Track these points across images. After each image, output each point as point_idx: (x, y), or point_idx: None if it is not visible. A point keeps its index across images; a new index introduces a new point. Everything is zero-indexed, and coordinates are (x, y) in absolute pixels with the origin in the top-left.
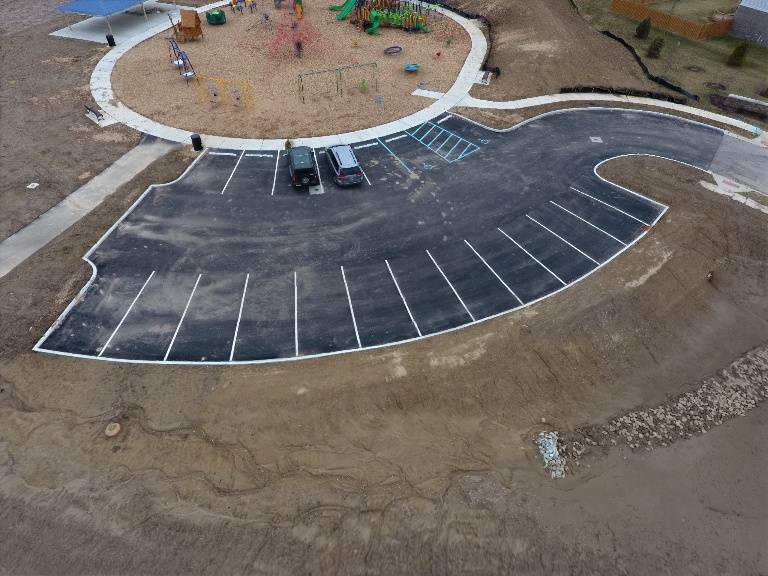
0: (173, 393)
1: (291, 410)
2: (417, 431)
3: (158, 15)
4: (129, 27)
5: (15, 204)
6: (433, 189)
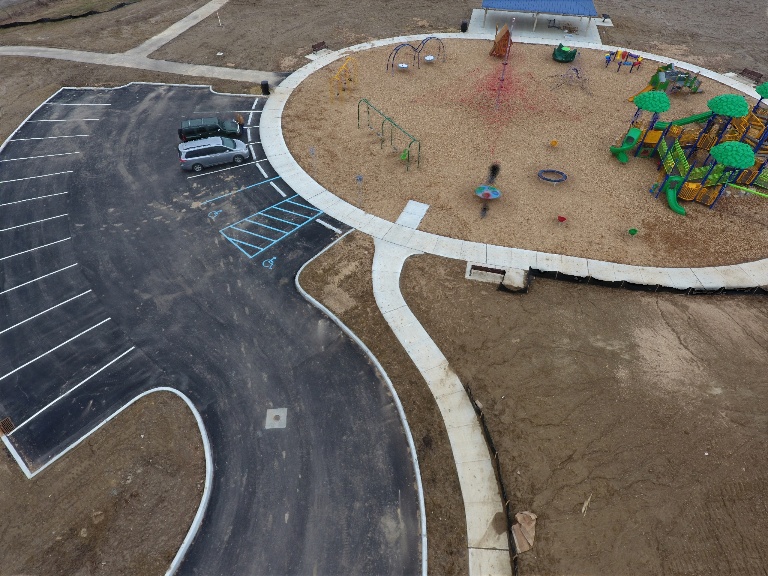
0: (0, 127)
1: None
2: None
3: (558, 32)
4: None
5: (198, 54)
6: (167, 218)
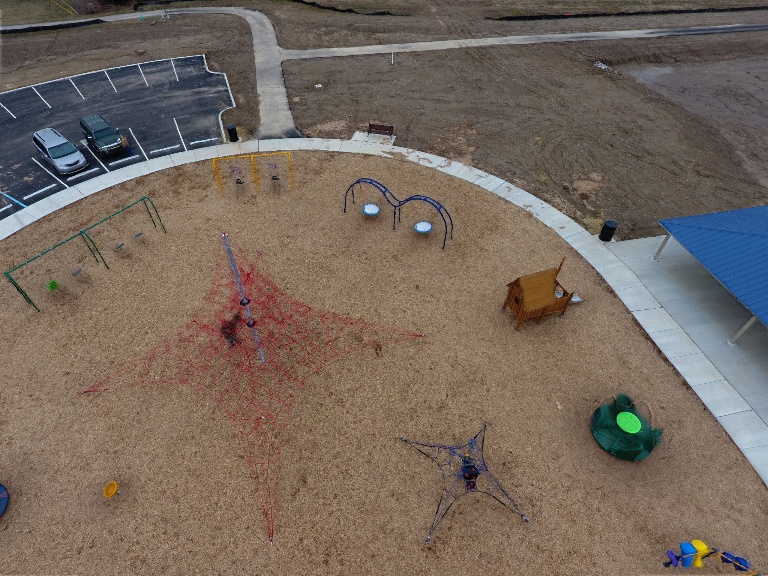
0: None
1: (66, 69)
2: (3, 82)
3: None
4: (710, 302)
5: (308, 77)
6: None
